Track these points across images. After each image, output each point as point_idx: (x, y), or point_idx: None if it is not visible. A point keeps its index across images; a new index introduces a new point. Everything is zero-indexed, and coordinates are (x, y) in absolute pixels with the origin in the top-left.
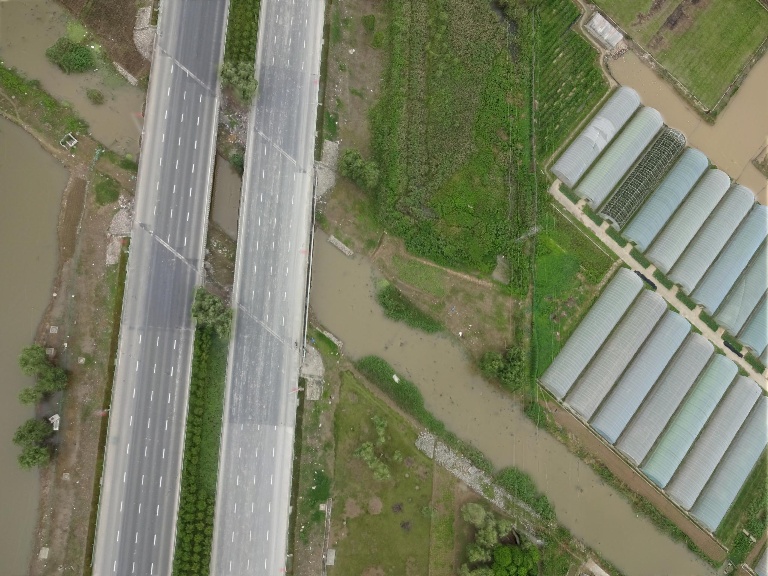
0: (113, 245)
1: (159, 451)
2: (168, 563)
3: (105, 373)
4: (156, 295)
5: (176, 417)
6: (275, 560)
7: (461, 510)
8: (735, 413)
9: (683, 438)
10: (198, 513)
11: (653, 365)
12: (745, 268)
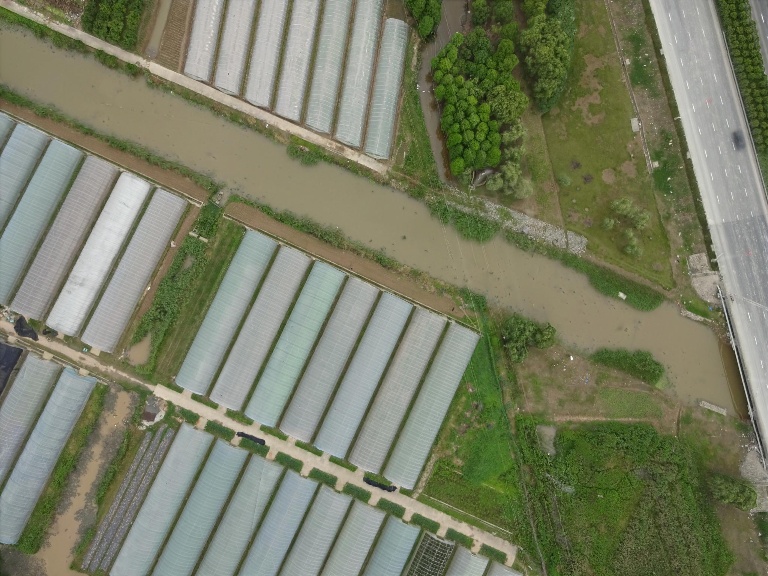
0: None
1: None
2: None
3: None
4: None
5: None
6: (687, 112)
7: None
8: (247, 364)
9: (309, 319)
10: None
11: (360, 388)
12: (251, 544)
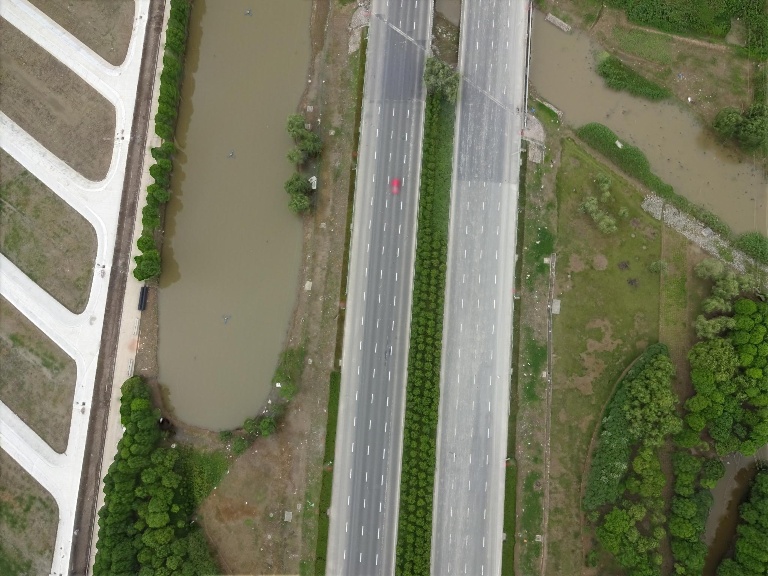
0: (354, 36)
1: (398, 203)
2: (408, 297)
3: (351, 140)
4: (391, 73)
5: (411, 175)
6: (503, 302)
7: (694, 269)
8: None
9: None
10: (433, 252)
11: None
12: None
